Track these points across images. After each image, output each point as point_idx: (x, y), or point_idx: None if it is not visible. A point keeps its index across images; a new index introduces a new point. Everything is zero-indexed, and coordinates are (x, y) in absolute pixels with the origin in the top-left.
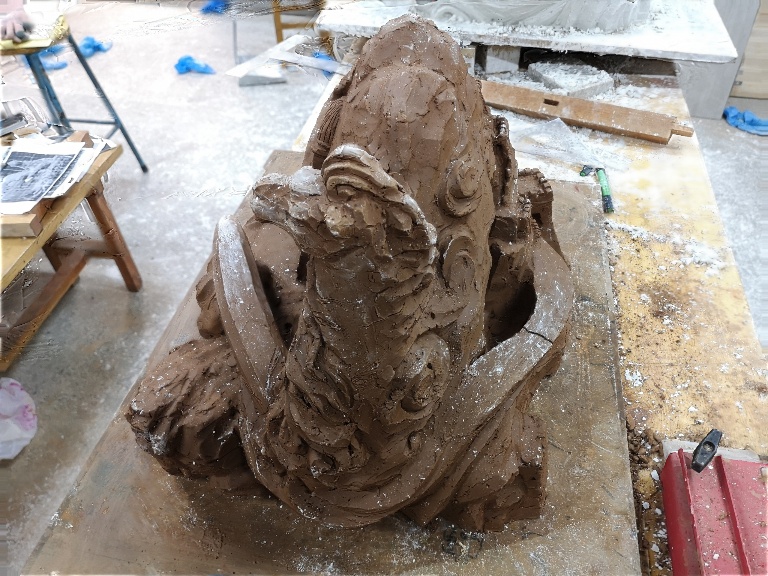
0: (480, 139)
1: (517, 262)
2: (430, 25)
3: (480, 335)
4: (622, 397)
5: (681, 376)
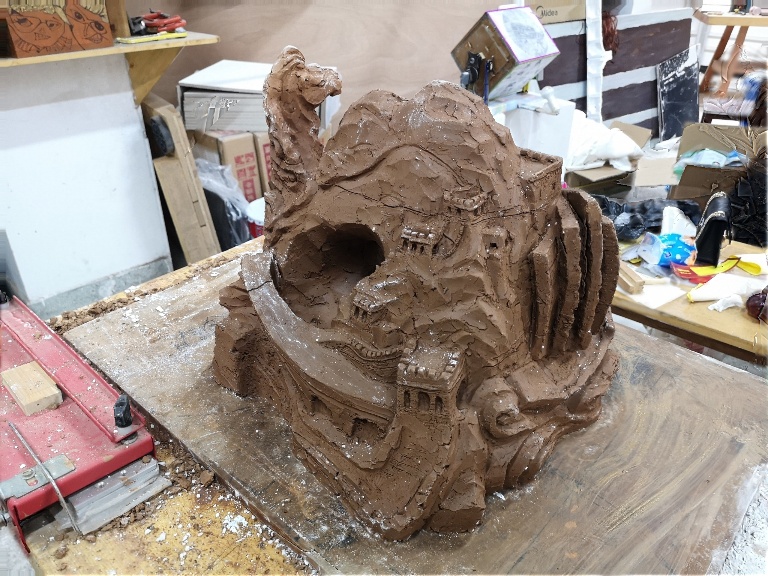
0: (372, 182)
1: (337, 317)
2: (432, 90)
3: (283, 256)
4: (225, 478)
5: (193, 562)
